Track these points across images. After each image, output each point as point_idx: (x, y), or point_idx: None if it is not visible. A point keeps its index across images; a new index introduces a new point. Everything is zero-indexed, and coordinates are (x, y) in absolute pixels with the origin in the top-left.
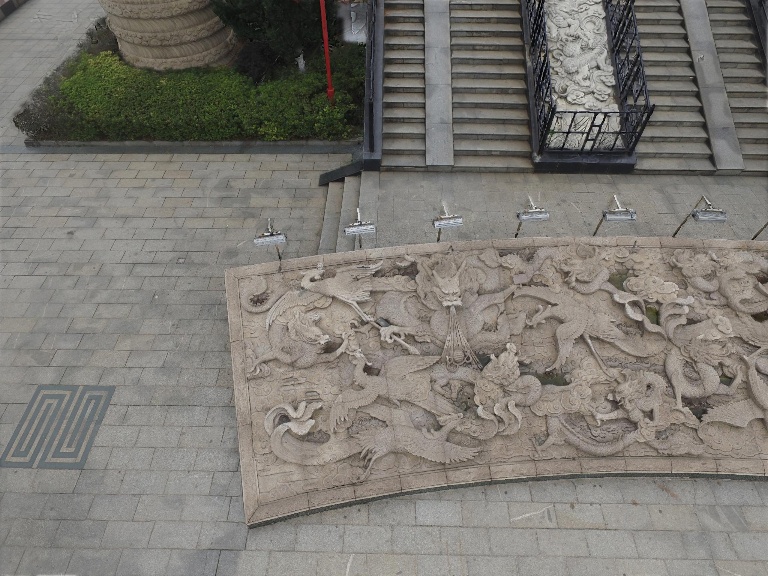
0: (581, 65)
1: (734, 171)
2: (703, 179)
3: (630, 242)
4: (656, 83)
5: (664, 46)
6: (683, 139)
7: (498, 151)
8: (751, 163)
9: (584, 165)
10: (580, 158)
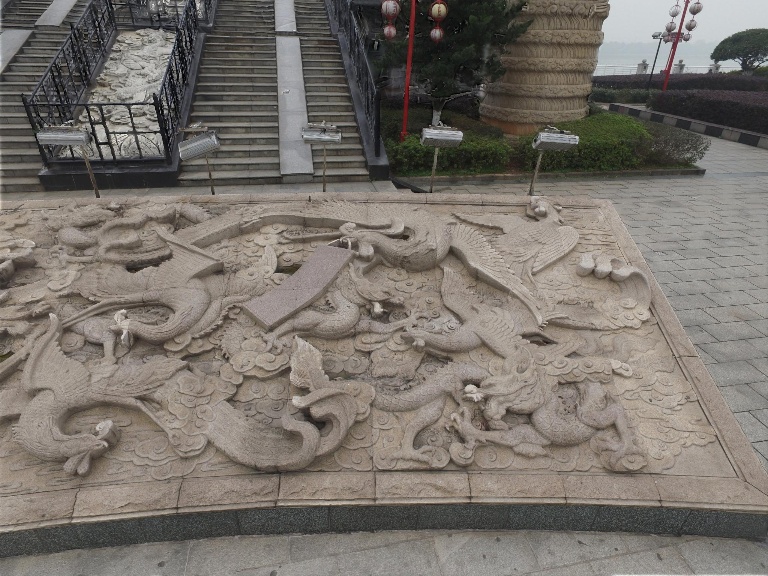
0: (136, 92)
1: (304, 177)
2: (267, 186)
3: (11, 205)
4: (236, 112)
5: (251, 85)
6: (252, 154)
7: (1, 171)
8: (327, 170)
9: (109, 177)
10: (103, 169)
